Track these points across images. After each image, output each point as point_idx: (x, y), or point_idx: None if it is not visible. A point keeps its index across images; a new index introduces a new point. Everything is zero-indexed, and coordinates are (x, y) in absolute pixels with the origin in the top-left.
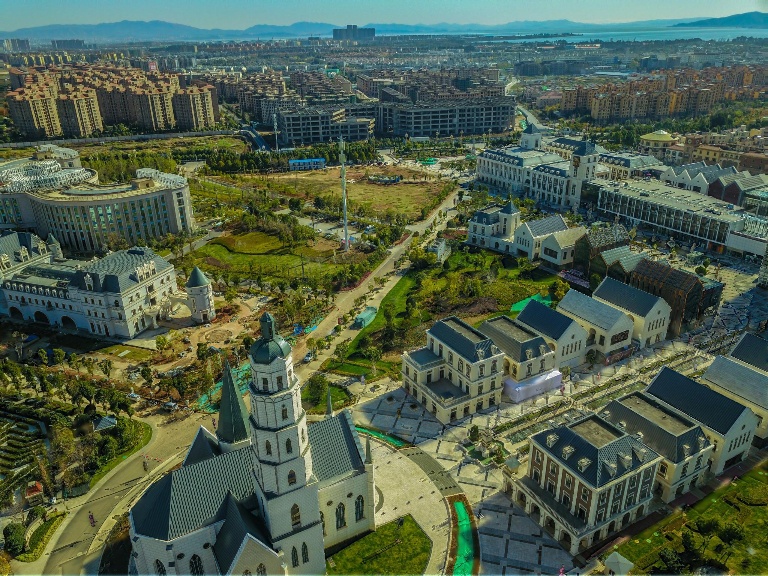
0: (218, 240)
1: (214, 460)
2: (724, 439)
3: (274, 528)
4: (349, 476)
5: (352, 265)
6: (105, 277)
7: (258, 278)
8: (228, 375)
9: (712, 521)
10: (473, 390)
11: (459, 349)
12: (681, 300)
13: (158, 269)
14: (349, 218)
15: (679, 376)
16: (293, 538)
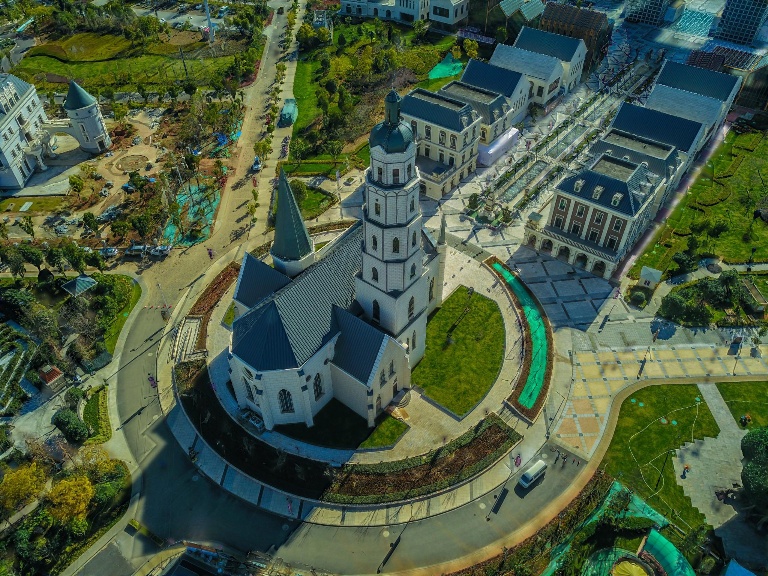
0: (37, 50)
1: (307, 278)
2: None
3: (397, 324)
4: (427, 261)
5: (243, 55)
6: None
7: (138, 87)
8: (286, 186)
9: (706, 222)
10: (459, 160)
11: (439, 121)
12: (592, 40)
13: (18, 93)
14: (188, 1)
15: (638, 108)
16: (408, 329)
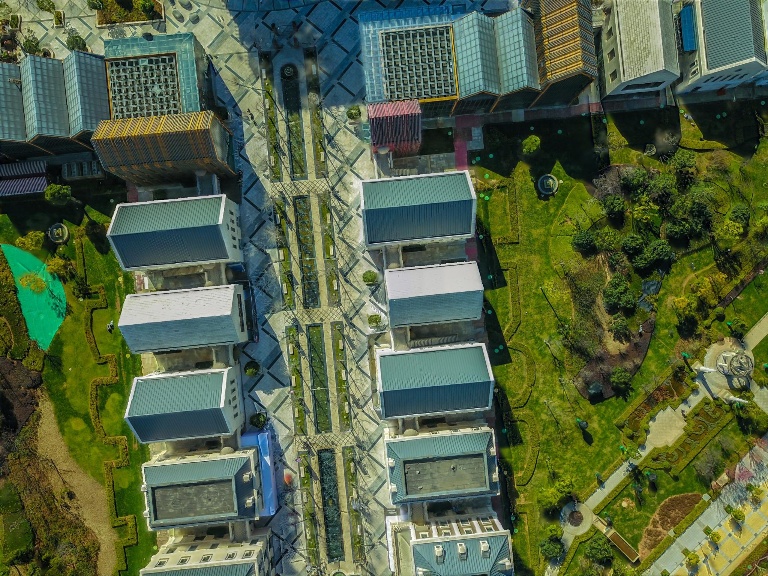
0: None
1: None
2: None
3: None
4: None
5: None
6: None
7: None
8: None
9: None
10: None
11: None
12: (215, 165)
13: None
14: None
15: (405, 392)
16: None
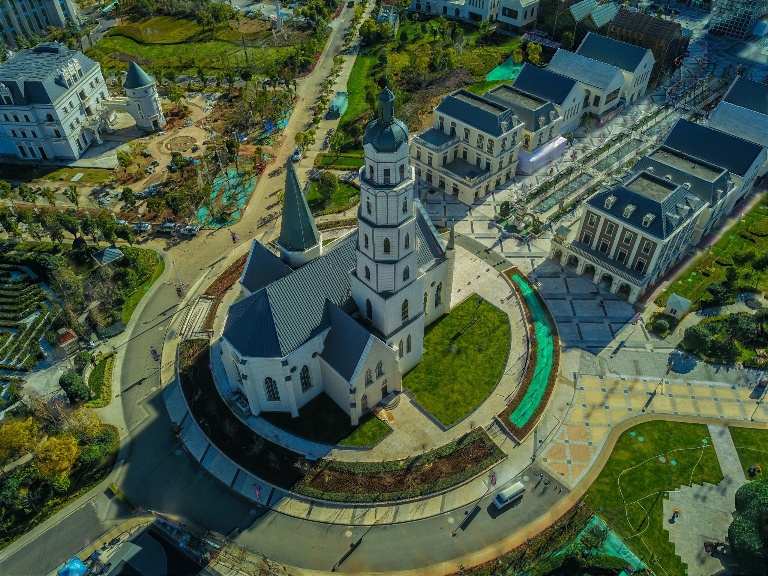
0: (117, 30)
1: (303, 270)
2: (743, 180)
3: (388, 326)
4: (433, 265)
5: (303, 45)
6: (24, 85)
7: (199, 71)
8: (293, 177)
9: (750, 253)
10: (495, 166)
11: (478, 124)
12: (662, 51)
13: (83, 69)
14: None
15: (695, 126)
16: (402, 332)
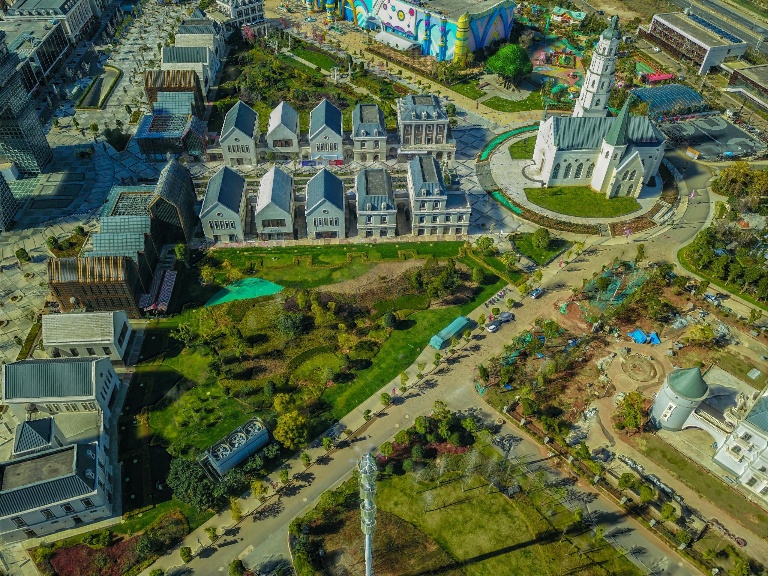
0: None
1: None
2: None
3: None
4: None
5: (426, 417)
6: None
7: None
8: None
9: None
10: None
11: None
12: None
13: (763, 401)
14: None
15: None
16: None
